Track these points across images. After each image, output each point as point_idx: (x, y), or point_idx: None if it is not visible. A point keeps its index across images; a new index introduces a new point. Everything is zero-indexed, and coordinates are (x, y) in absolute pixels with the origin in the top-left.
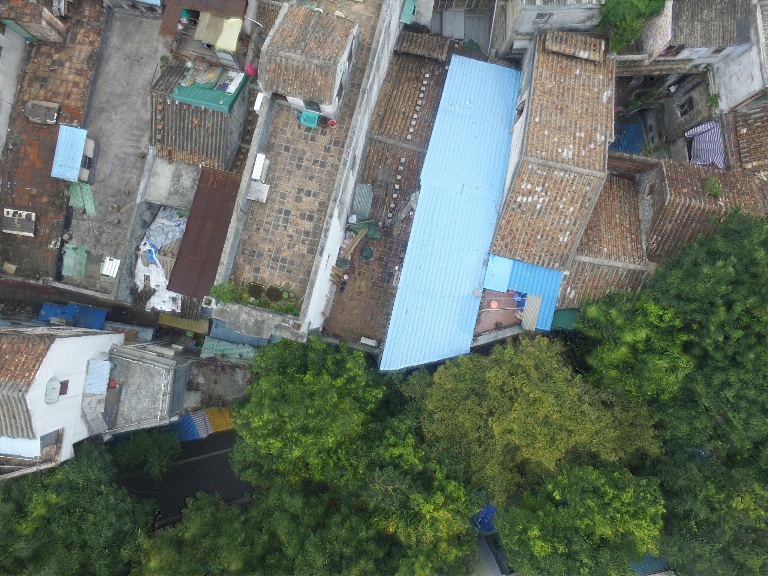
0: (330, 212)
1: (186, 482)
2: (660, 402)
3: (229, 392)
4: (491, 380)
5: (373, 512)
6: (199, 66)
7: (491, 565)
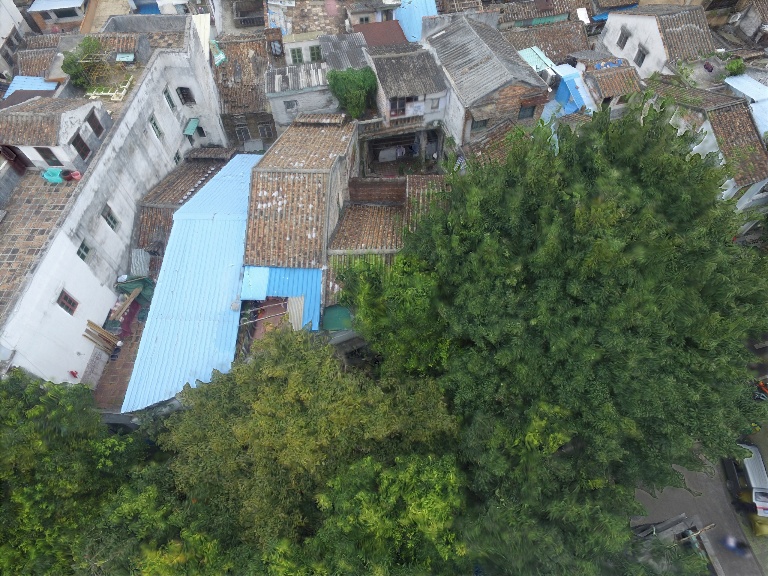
0: (51, 234)
1: None
2: None
3: None
4: (236, 380)
5: None
6: None
7: None
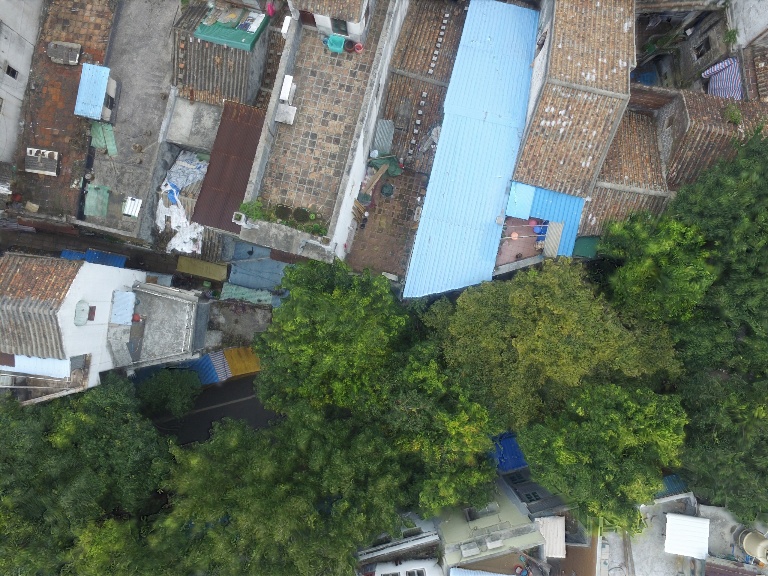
0: (357, 132)
1: (203, 430)
2: (681, 324)
3: (249, 332)
4: (515, 301)
5: (396, 438)
6: (220, 7)
7: (510, 496)
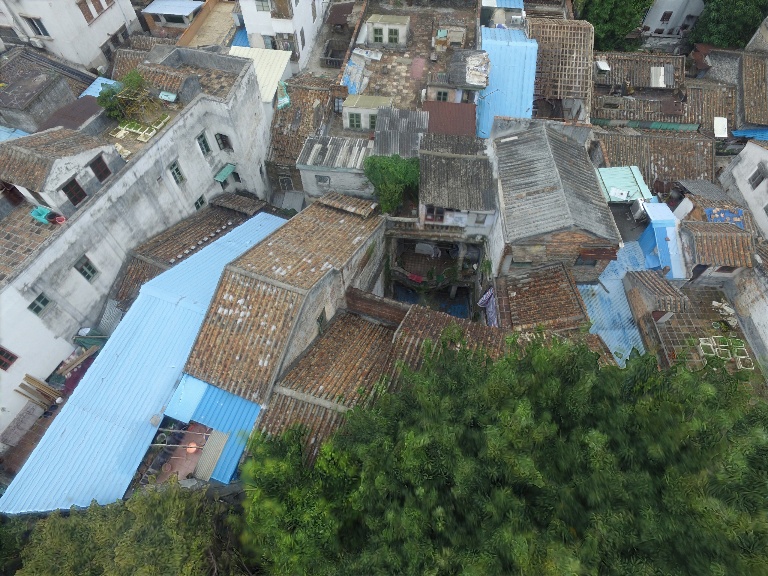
0: None
1: None
2: None
3: None
4: (96, 535)
5: None
6: None
7: None
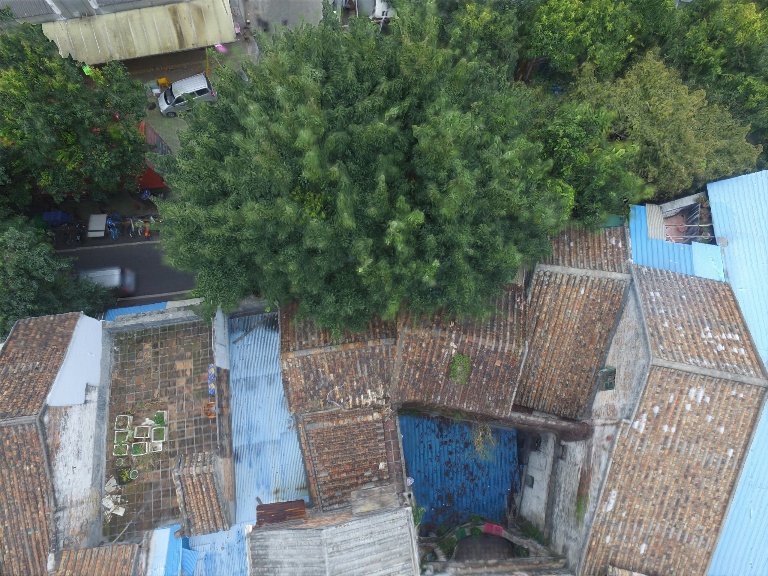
0: None
1: None
2: None
3: None
4: None
5: None
6: None
7: None
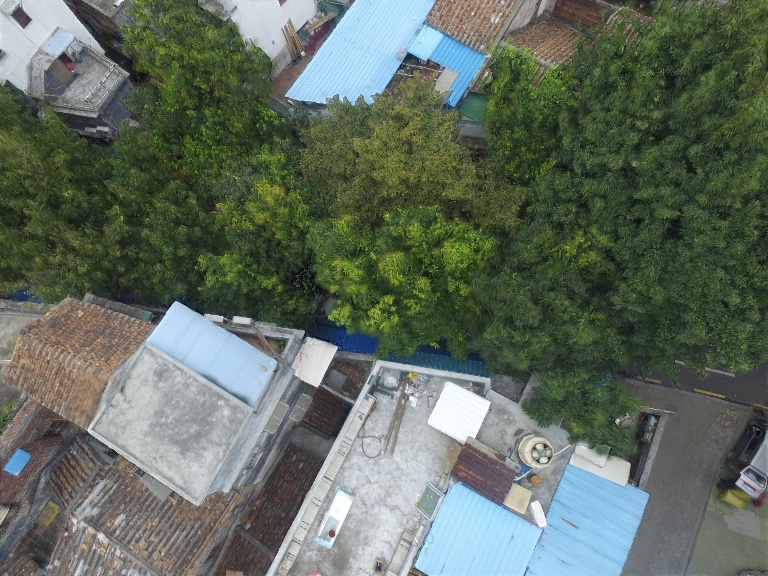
0: None
1: None
2: None
3: None
4: (373, 106)
5: None
6: None
7: None
